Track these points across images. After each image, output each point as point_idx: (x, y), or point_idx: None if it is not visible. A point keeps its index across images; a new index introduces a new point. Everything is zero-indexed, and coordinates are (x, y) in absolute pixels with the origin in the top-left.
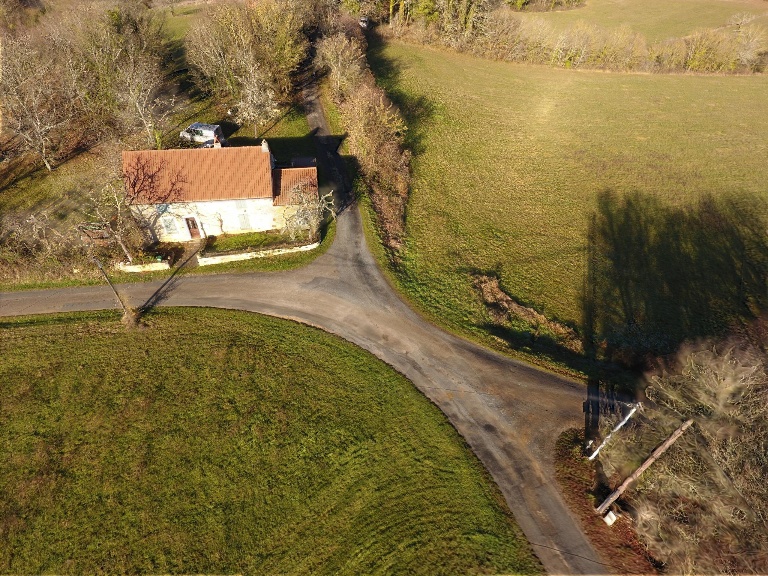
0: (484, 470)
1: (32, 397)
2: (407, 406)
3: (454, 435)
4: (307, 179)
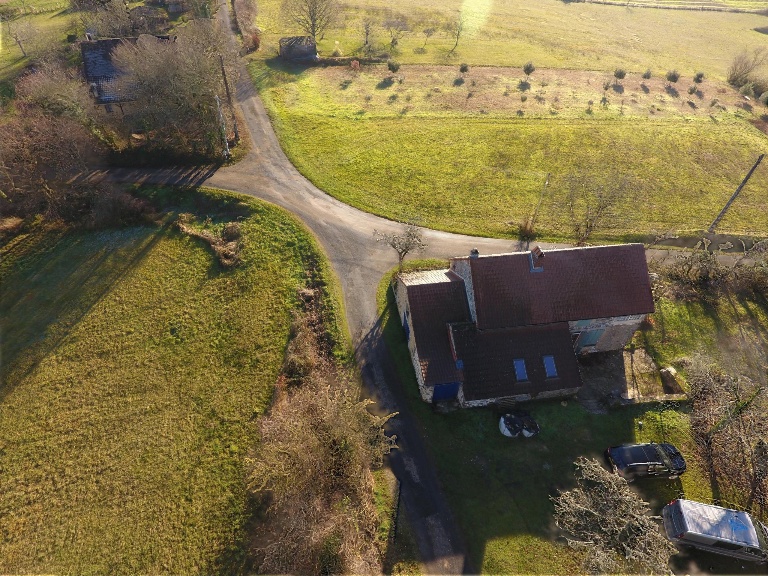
0: (285, 151)
1: (546, 193)
2: (319, 175)
3: (295, 162)
4: (416, 281)
